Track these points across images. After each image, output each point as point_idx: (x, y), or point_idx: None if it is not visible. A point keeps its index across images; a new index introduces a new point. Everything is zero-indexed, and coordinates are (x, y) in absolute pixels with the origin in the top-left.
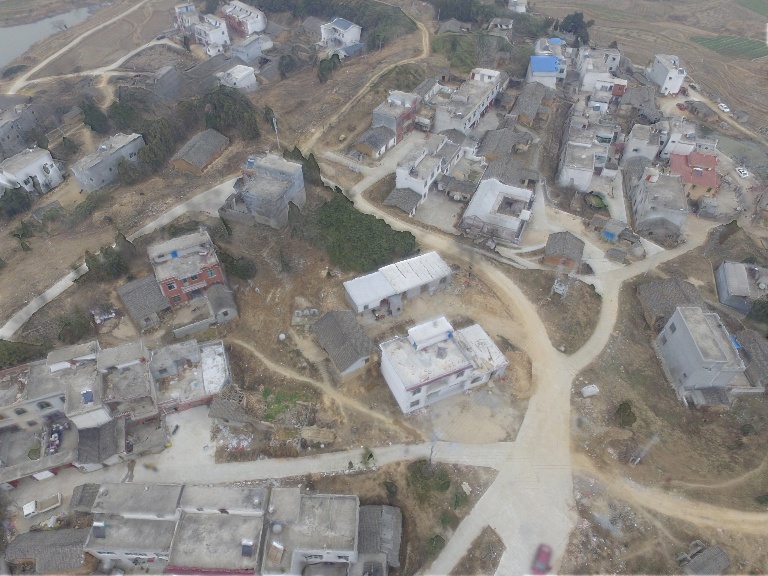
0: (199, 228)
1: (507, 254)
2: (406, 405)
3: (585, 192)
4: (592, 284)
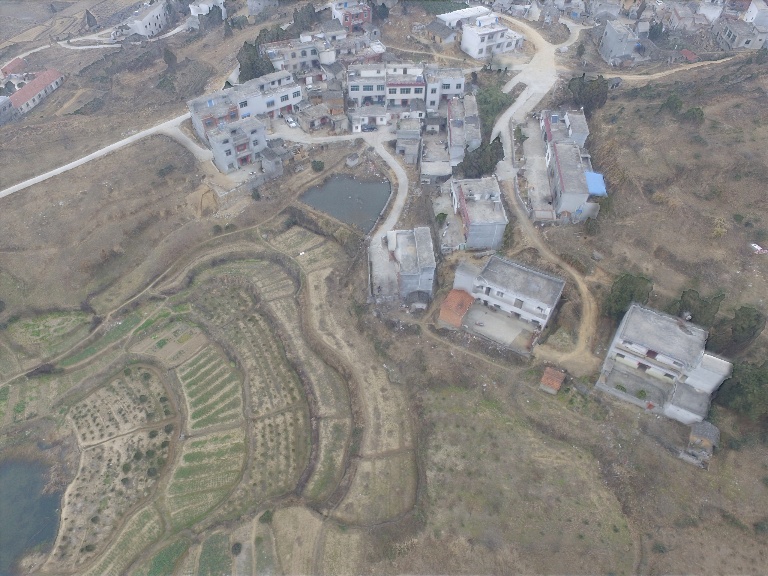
0: None
1: None
2: (477, 51)
3: (562, 10)
4: (565, 24)
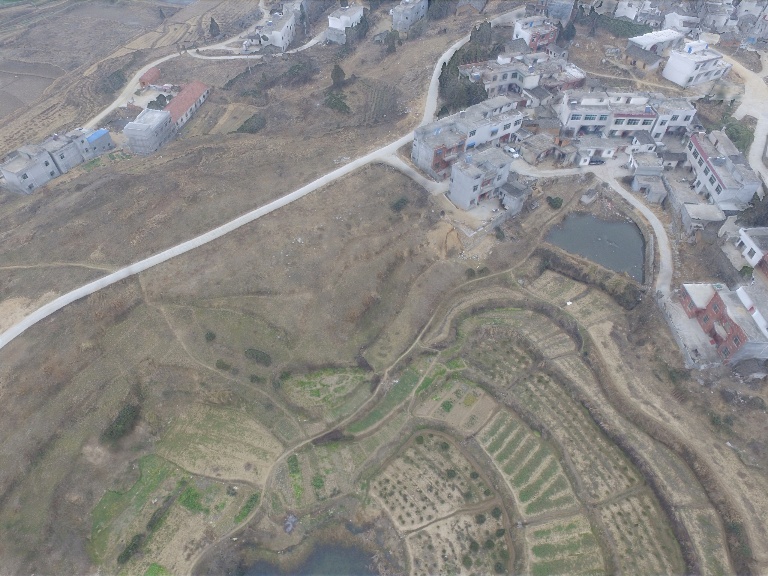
0: None
1: None
2: (687, 79)
3: None
4: (755, 51)
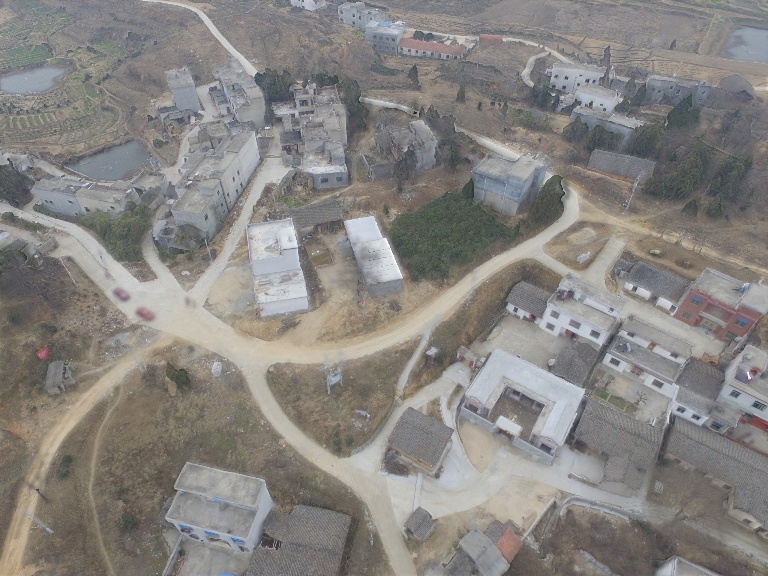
0: (475, 160)
1: (439, 390)
2: None
3: None
4: (351, 438)
